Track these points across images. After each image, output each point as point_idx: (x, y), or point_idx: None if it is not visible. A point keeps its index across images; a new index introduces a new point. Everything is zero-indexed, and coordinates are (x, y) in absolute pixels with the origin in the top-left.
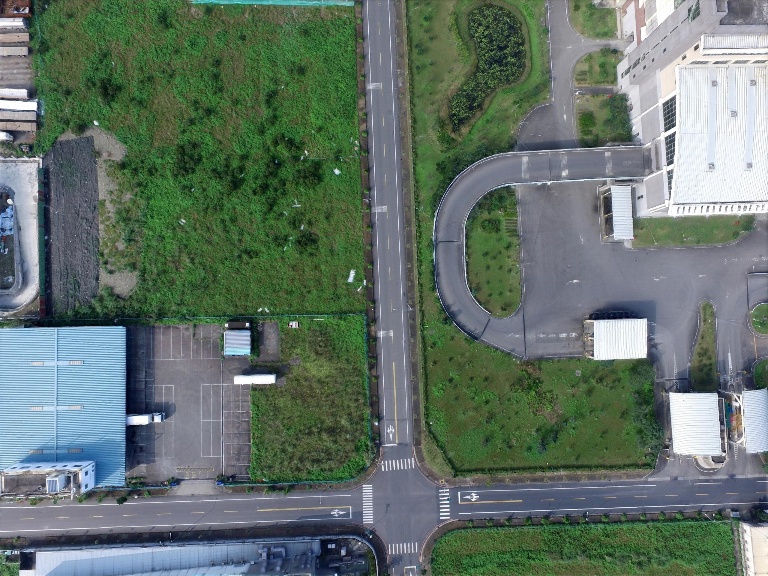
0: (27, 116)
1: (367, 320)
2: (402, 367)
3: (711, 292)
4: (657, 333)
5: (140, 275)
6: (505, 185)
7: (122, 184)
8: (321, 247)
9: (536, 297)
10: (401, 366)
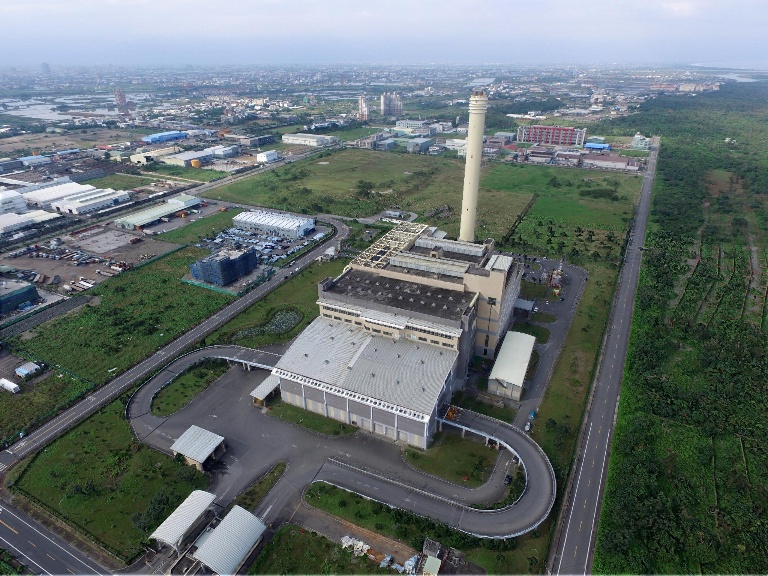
0: (85, 287)
1: (92, 388)
2: (75, 416)
3: (293, 458)
4: (233, 466)
5: (38, 335)
6: (222, 357)
7: (81, 311)
8: (117, 354)
9: (184, 414)
10: (76, 416)
